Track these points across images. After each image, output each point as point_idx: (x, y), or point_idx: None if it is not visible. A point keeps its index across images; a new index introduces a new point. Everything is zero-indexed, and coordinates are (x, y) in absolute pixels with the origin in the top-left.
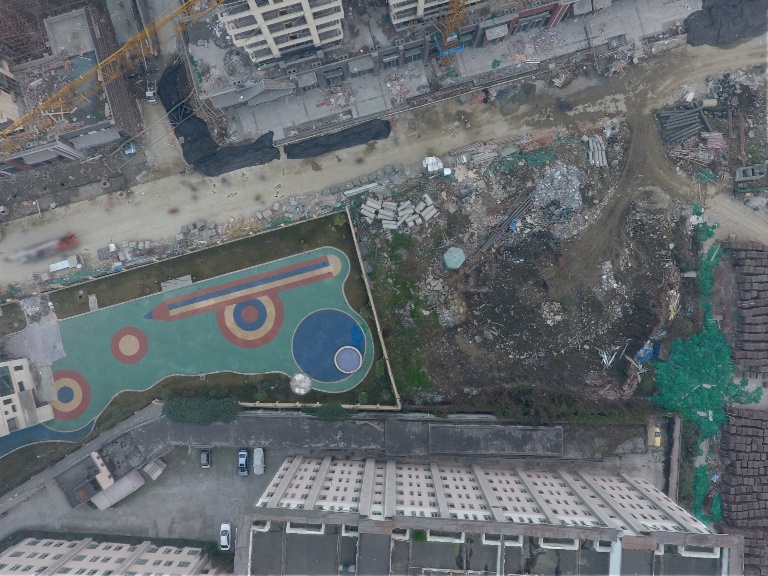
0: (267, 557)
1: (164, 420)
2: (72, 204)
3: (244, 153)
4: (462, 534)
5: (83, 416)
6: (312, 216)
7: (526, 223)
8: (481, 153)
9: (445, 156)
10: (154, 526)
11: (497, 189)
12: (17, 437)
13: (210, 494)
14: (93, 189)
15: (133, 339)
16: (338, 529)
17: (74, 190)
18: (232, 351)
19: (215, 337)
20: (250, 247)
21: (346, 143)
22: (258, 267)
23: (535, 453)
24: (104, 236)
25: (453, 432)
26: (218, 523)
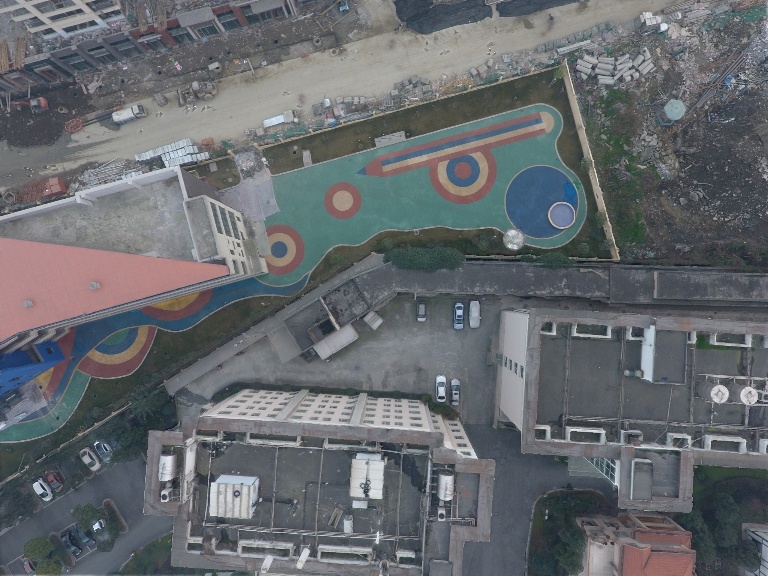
0: (549, 364)
1: (389, 267)
2: (285, 61)
3: (456, 11)
4: (748, 339)
5: (297, 271)
6: (526, 72)
7: (739, 80)
8: (695, 10)
9: (657, 14)
10: (368, 380)
11: (710, 47)
12: (231, 291)
13: (424, 348)
14: (304, 48)
15: (347, 194)
16: (622, 335)
17: (285, 49)
18: (445, 207)
19: (428, 193)
20: (464, 103)
21: (559, 1)
22: (471, 123)
23: (762, 299)
24: (317, 93)
25: (680, 278)
26: (432, 377)
